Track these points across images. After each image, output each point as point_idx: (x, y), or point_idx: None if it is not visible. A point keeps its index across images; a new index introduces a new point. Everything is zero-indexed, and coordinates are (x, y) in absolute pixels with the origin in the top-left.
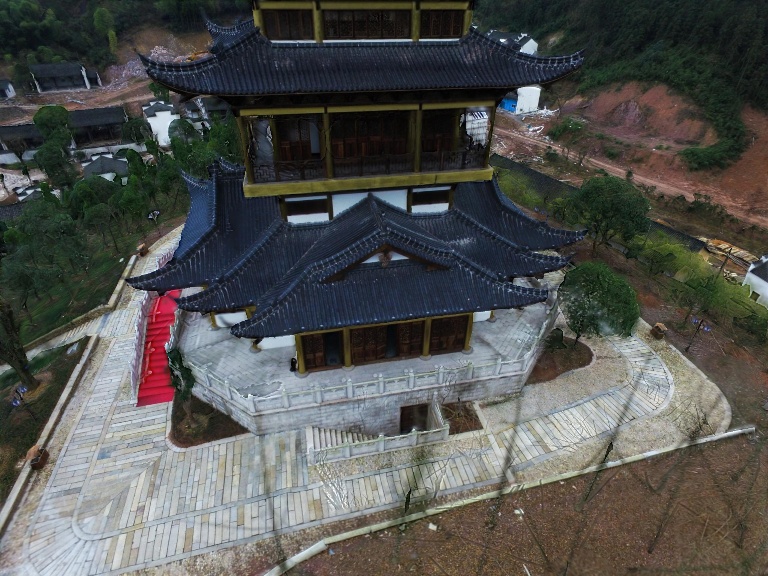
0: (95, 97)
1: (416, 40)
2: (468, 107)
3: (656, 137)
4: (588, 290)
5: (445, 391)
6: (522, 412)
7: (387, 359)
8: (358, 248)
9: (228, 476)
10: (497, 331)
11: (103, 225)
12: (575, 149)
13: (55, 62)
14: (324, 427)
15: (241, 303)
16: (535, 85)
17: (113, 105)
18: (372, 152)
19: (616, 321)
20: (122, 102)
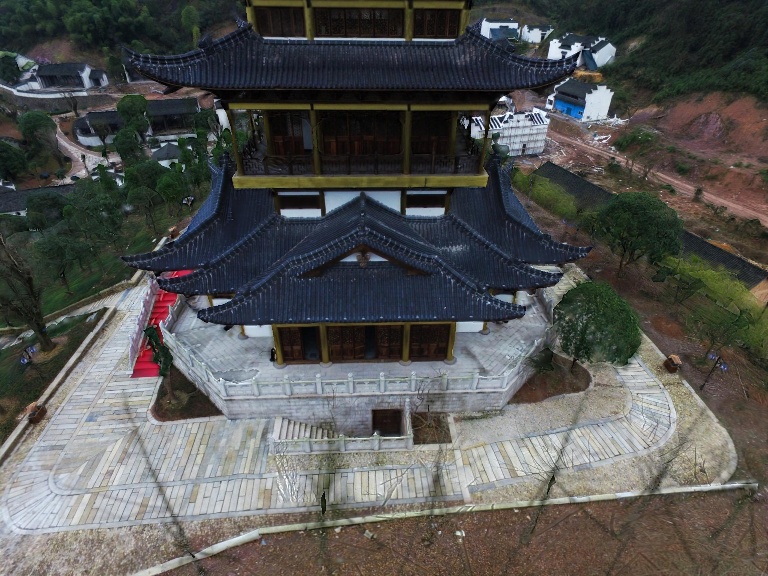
0: None
1: (409, 39)
2: (460, 110)
3: (737, 153)
4: (583, 311)
5: (418, 399)
6: (497, 431)
7: (366, 360)
8: (336, 246)
9: (193, 454)
10: (487, 344)
11: None
12: (642, 161)
13: None
14: (294, 419)
15: (223, 290)
16: (526, 89)
17: (190, 96)
18: (365, 151)
19: (609, 347)
20: (198, 94)
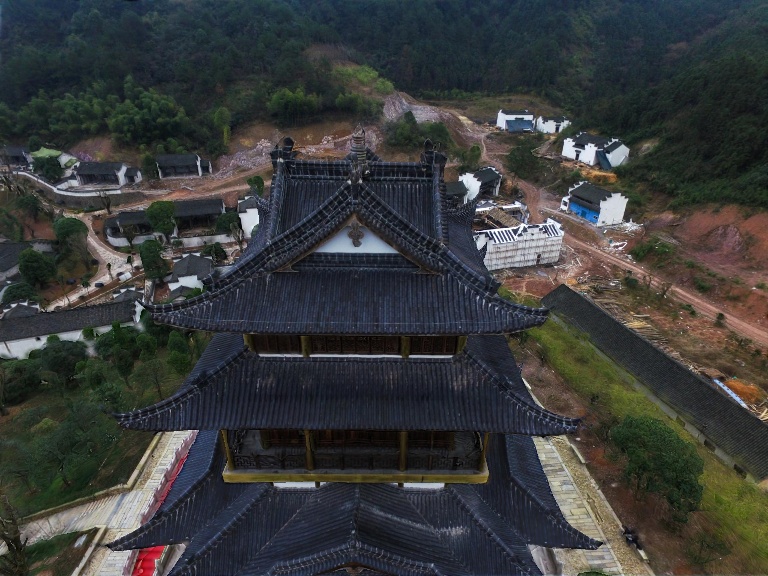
0: (203, 184)
1: (405, 357)
2: None
3: (758, 271)
4: None
5: None
6: None
7: None
8: (326, 557)
9: None
10: None
11: (165, 349)
12: (660, 274)
13: (178, 152)
14: None
15: None
16: None
17: (216, 193)
18: (361, 436)
19: None
20: (224, 191)
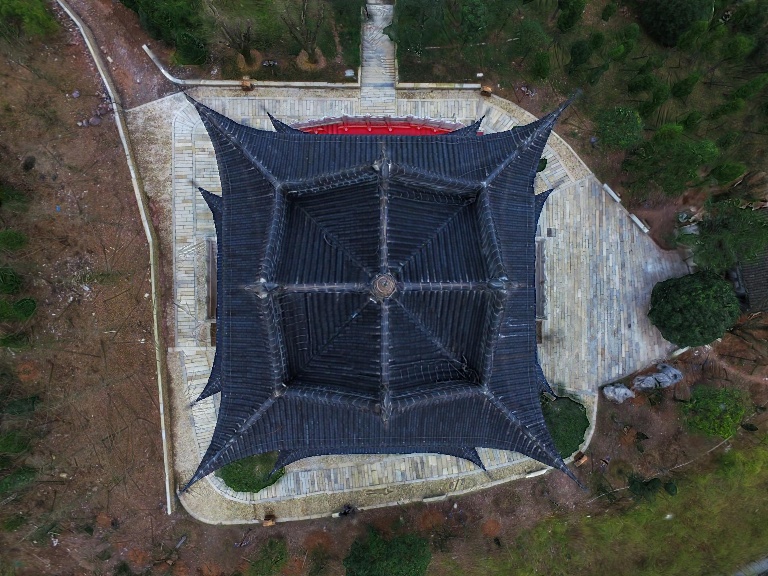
0: None
1: None
2: None
3: None
4: None
5: None
6: None
7: None
8: None
9: None
10: None
11: None
12: None
13: None
14: None
15: None
16: None
17: None
18: None
19: None
20: None
